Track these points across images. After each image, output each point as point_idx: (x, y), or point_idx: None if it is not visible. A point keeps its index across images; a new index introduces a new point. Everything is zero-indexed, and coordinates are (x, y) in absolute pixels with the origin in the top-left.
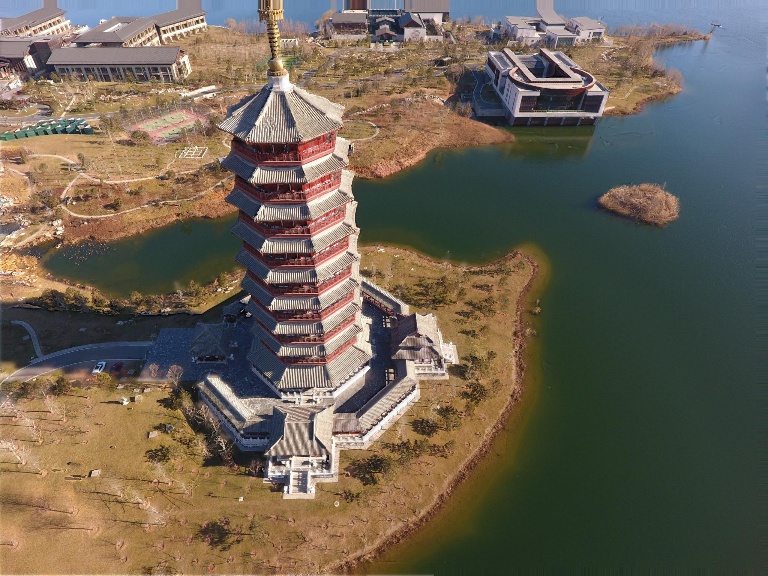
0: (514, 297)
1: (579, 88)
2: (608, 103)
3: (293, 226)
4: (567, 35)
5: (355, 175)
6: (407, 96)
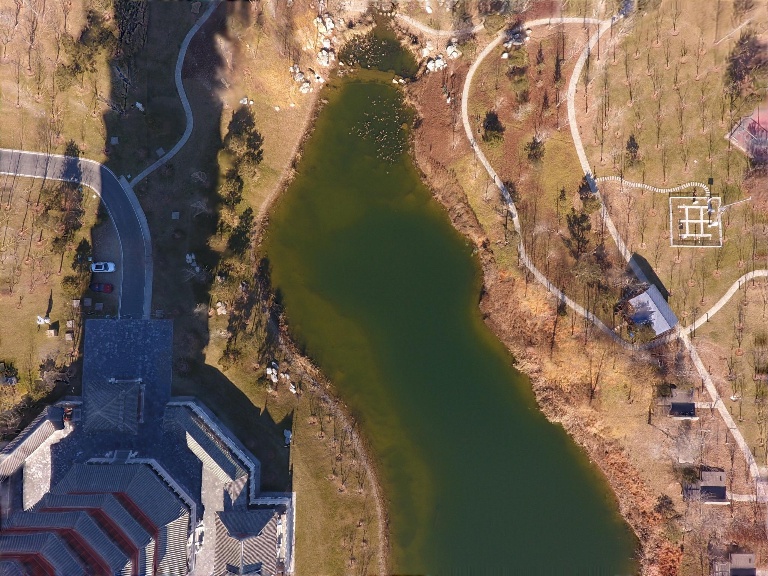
0: None
1: None
2: None
3: None
4: None
5: (645, 572)
6: None
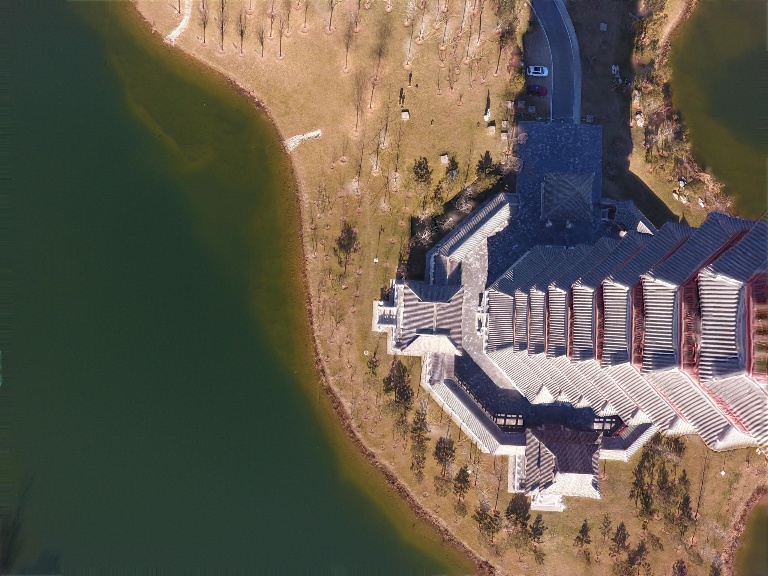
0: None
1: None
2: None
3: None
4: None
5: None
6: None
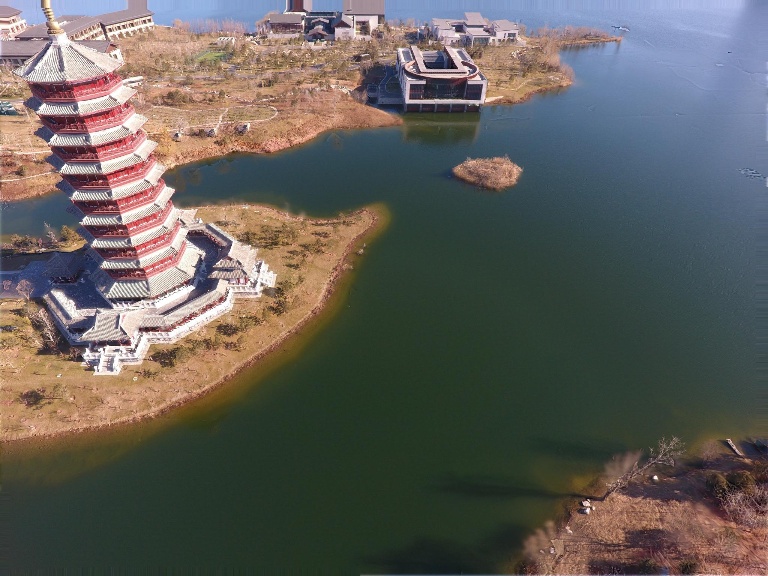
0: (346, 242)
1: (460, 78)
2: (498, 93)
3: (86, 153)
4: (482, 35)
5: (247, 150)
6: (316, 86)
